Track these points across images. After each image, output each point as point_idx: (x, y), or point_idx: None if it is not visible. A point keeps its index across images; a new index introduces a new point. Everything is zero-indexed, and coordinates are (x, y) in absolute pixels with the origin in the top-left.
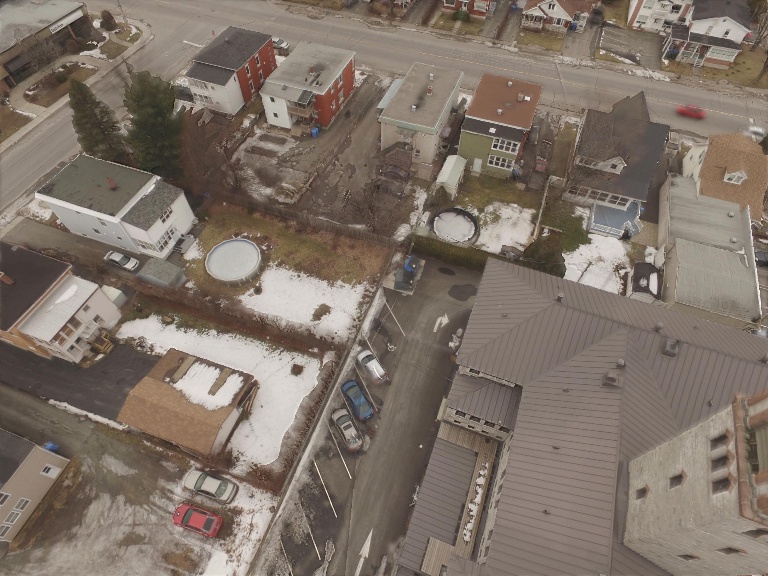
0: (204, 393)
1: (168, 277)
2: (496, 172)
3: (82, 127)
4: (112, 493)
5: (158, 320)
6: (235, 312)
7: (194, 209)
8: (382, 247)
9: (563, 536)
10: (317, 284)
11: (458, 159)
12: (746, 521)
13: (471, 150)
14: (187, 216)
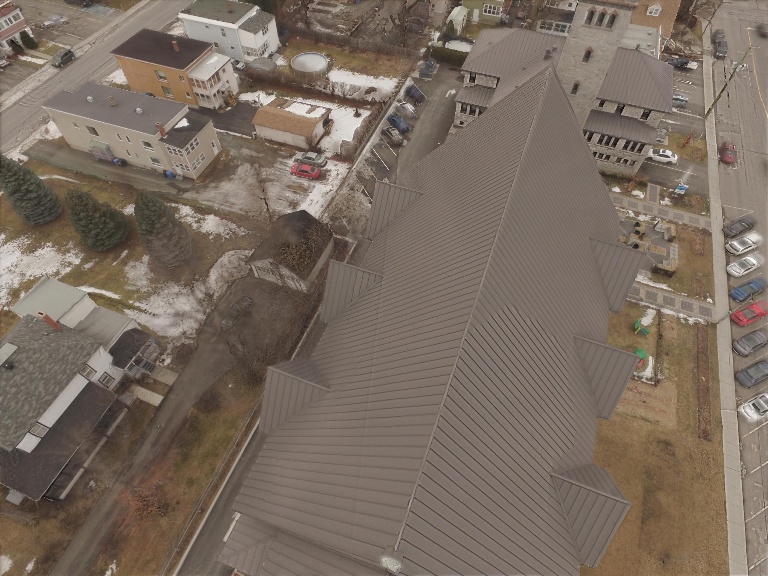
0: (303, 112)
1: (269, 66)
2: (489, 20)
3: None
4: (251, 163)
5: (263, 93)
6: (316, 80)
7: (279, 36)
8: (409, 60)
9: None
10: (366, 78)
11: (462, 8)
12: (583, 7)
13: (471, 2)
14: (275, 39)
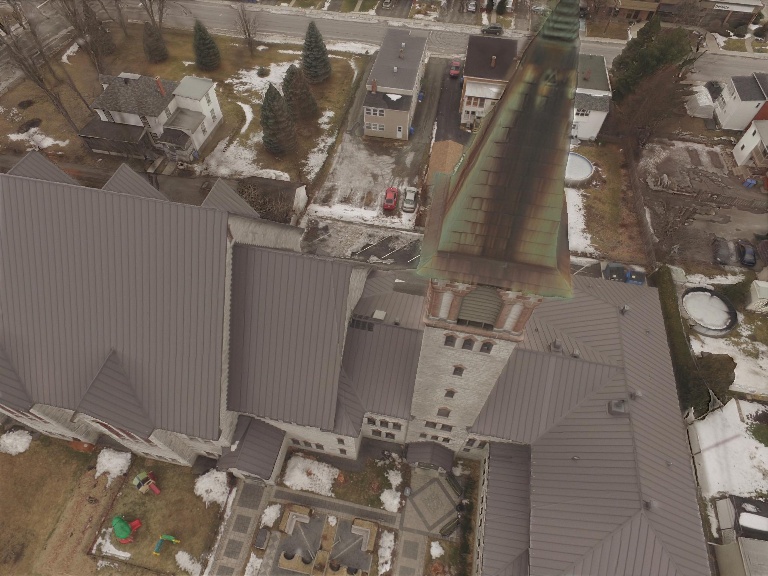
0: None
1: None
2: None
3: (628, 48)
4: (396, 162)
5: None
6: None
7: (602, 132)
8: (644, 258)
9: (420, 316)
10: (579, 222)
11: None
12: None
13: None
14: (593, 130)
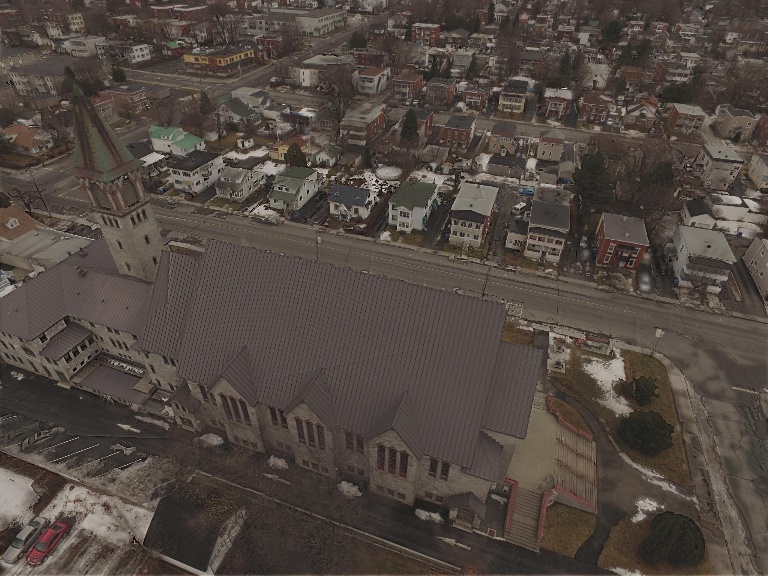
0: None
1: None
2: None
3: None
4: None
5: None
6: None
7: None
8: None
9: (138, 302)
10: None
11: None
12: (126, 219)
13: None
14: None
